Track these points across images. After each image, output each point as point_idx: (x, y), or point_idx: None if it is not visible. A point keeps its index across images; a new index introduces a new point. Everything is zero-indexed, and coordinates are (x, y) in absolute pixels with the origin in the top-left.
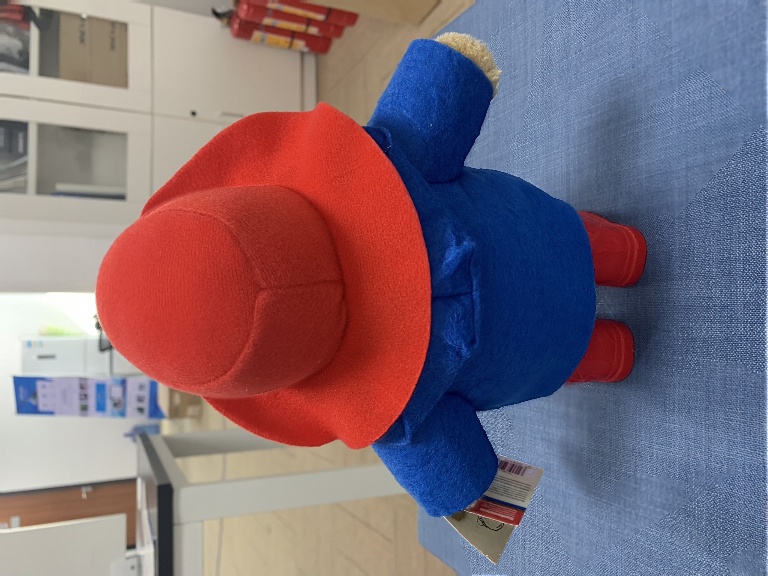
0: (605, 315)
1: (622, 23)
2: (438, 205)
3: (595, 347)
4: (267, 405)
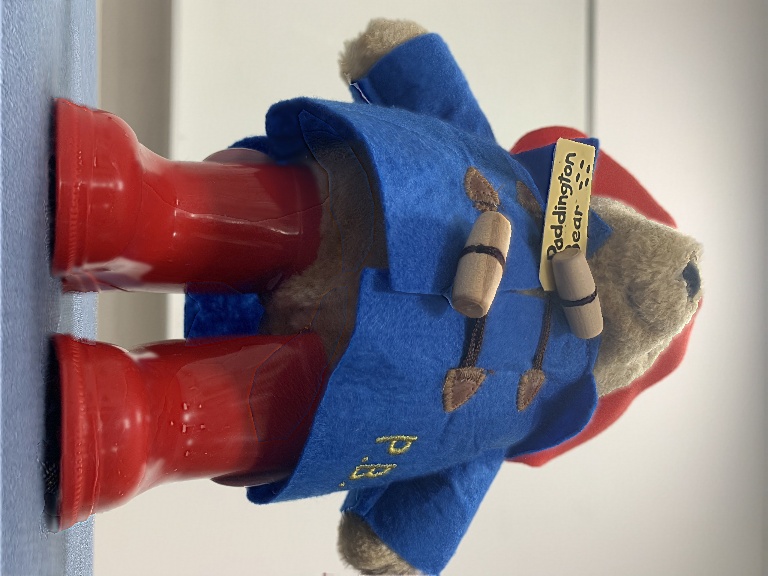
0: None
1: None
2: None
3: None
4: None
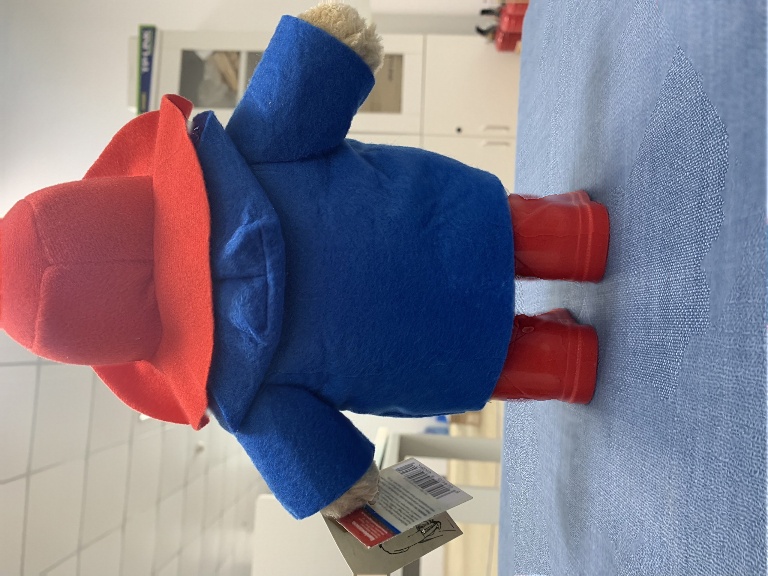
0: (586, 319)
1: None
2: (243, 184)
3: (539, 356)
4: (147, 380)
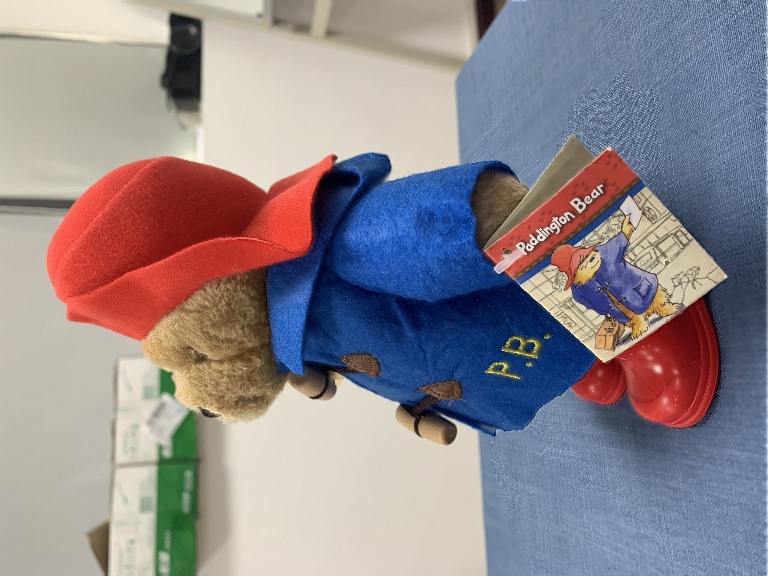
0: None
1: None
2: None
3: None
4: None
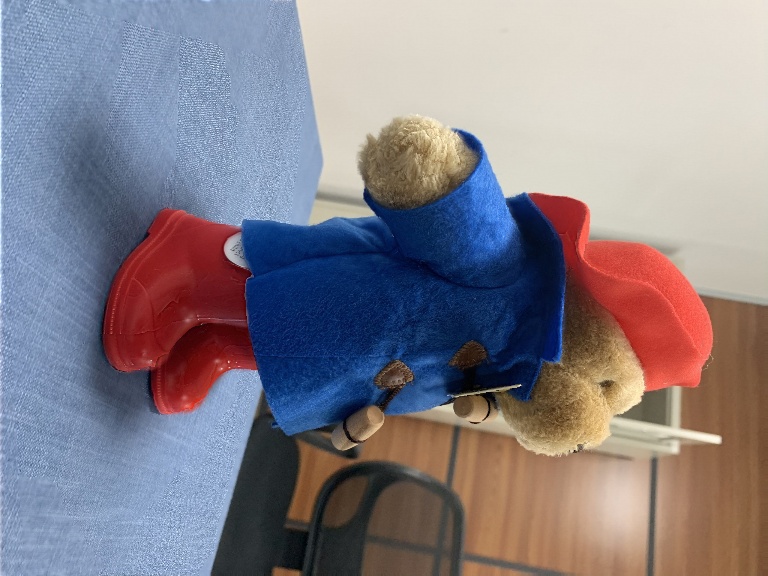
0: None
1: (8, 32)
2: None
3: None
4: None
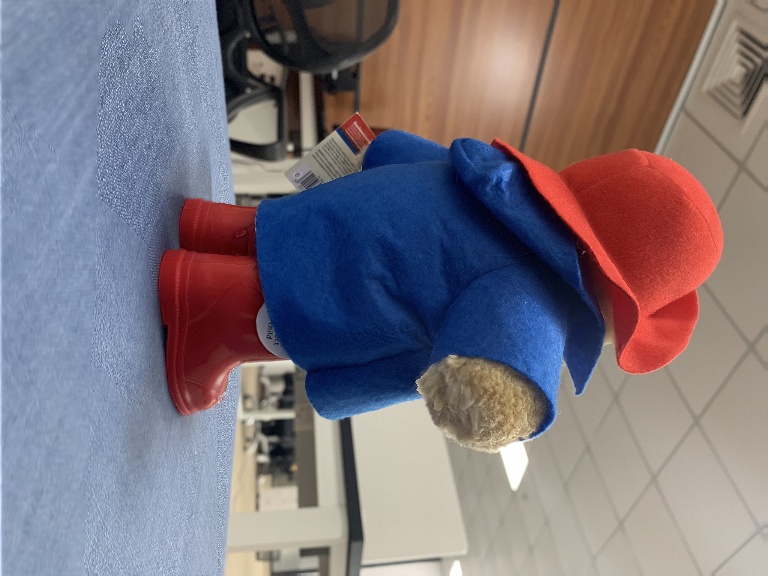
0: None
1: None
2: (519, 216)
3: None
4: None
